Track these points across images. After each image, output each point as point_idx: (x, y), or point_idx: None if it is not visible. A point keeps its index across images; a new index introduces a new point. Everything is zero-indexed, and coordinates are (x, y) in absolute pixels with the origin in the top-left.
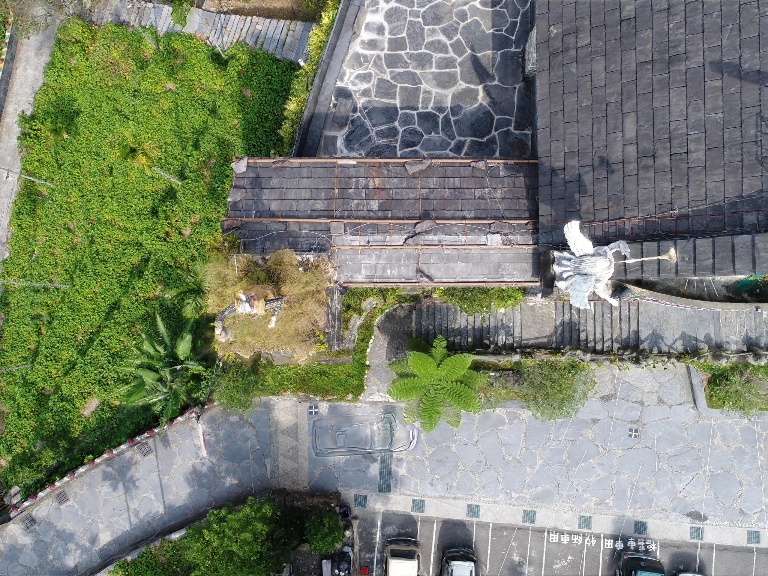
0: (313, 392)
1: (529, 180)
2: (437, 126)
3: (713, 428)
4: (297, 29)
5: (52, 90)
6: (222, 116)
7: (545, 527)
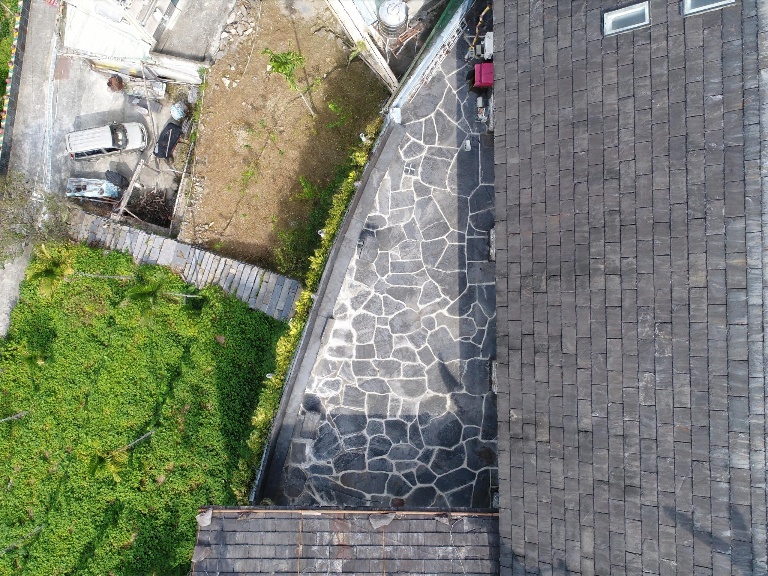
0: None
1: (493, 537)
2: (405, 434)
3: None
4: (270, 281)
5: (28, 308)
6: (196, 365)
7: None
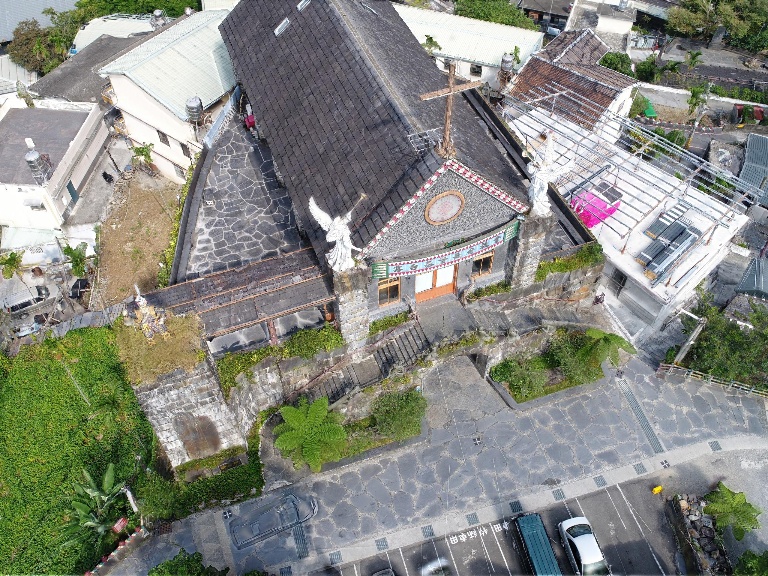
0: (223, 496)
1: (311, 254)
2: None
3: (530, 418)
4: None
5: None
6: (116, 354)
7: (444, 535)
